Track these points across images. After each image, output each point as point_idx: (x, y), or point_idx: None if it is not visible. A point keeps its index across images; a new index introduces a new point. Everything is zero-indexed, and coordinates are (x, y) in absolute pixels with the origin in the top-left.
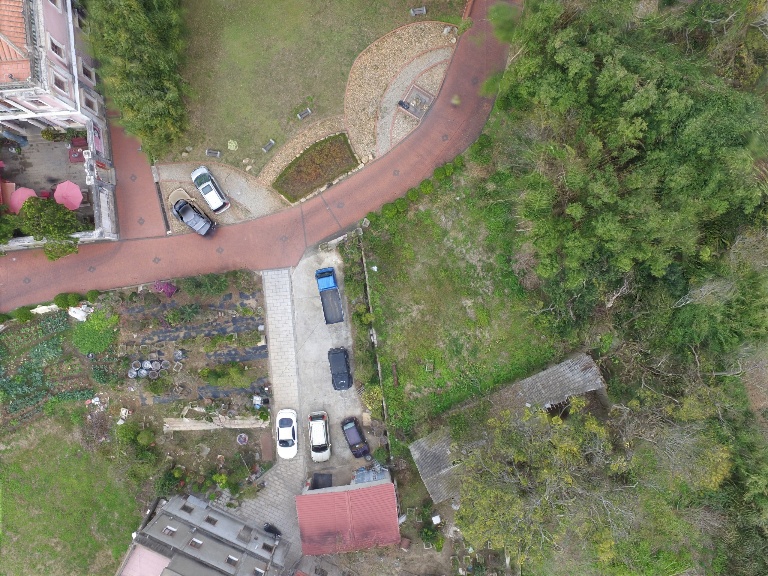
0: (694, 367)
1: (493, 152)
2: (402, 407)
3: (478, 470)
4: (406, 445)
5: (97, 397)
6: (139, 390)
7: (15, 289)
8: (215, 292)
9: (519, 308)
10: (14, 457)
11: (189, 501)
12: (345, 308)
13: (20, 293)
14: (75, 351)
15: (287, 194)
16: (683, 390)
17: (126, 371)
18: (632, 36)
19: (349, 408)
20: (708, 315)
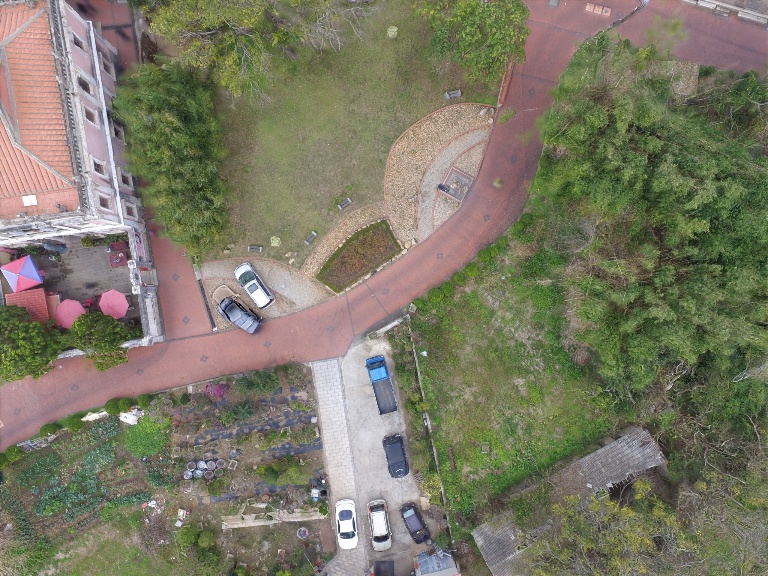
0: (754, 440)
1: (536, 230)
2: (460, 490)
3: (546, 559)
4: (468, 531)
5: (153, 500)
6: None
7: (63, 397)
8: (268, 391)
9: (575, 389)
10: (74, 565)
11: None
12: (396, 394)
13: (69, 401)
14: (128, 455)
15: (332, 285)
16: (745, 464)
17: (181, 473)
18: (674, 113)
19: (406, 493)
20: (763, 384)
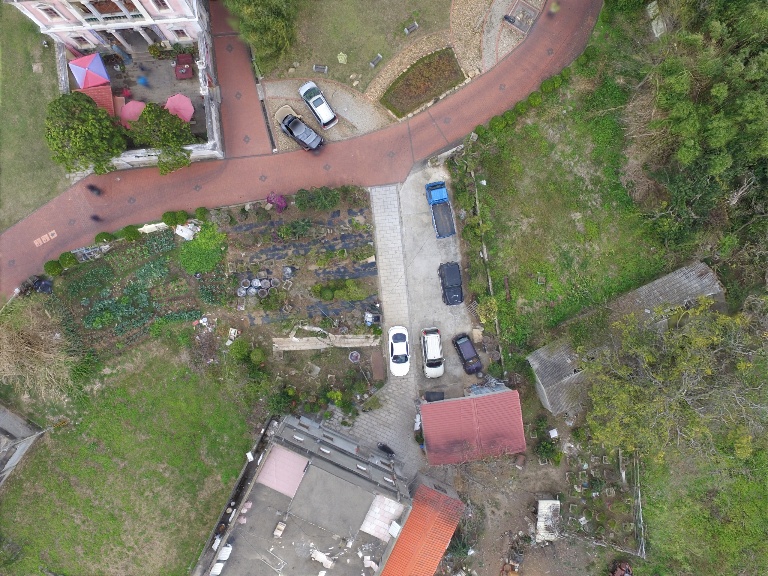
0: None
1: (599, 64)
2: (514, 321)
3: (606, 372)
4: (523, 356)
5: (205, 317)
6: (247, 310)
7: (120, 209)
8: (329, 204)
9: (635, 214)
10: (120, 381)
11: (302, 420)
12: None
13: (125, 213)
14: (181, 272)
15: (395, 109)
16: None
17: (235, 290)
18: None
19: (459, 325)
20: None
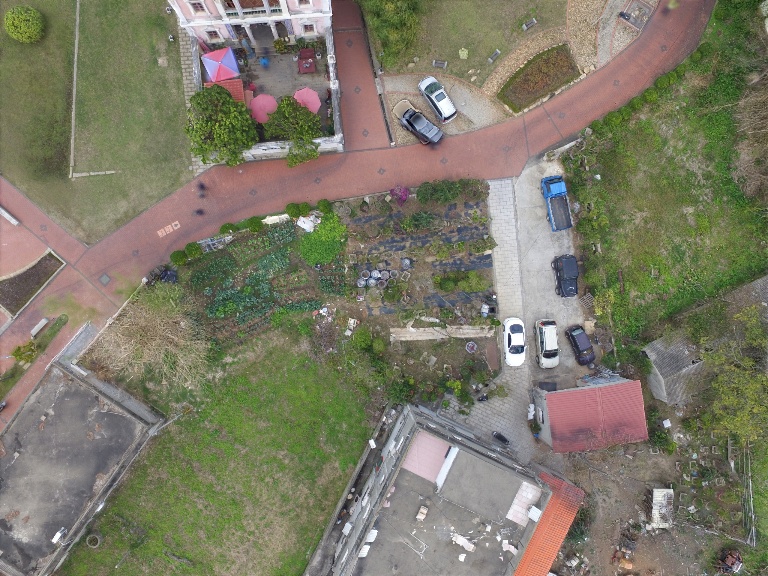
0: None
1: (713, 61)
2: (627, 313)
3: (730, 363)
4: (640, 347)
5: (325, 307)
6: (366, 300)
7: (241, 201)
8: (452, 197)
9: (753, 208)
10: (241, 369)
11: (421, 409)
12: None
13: (246, 205)
14: (301, 262)
15: (512, 104)
16: None
17: (354, 281)
18: None
19: (571, 317)
20: None
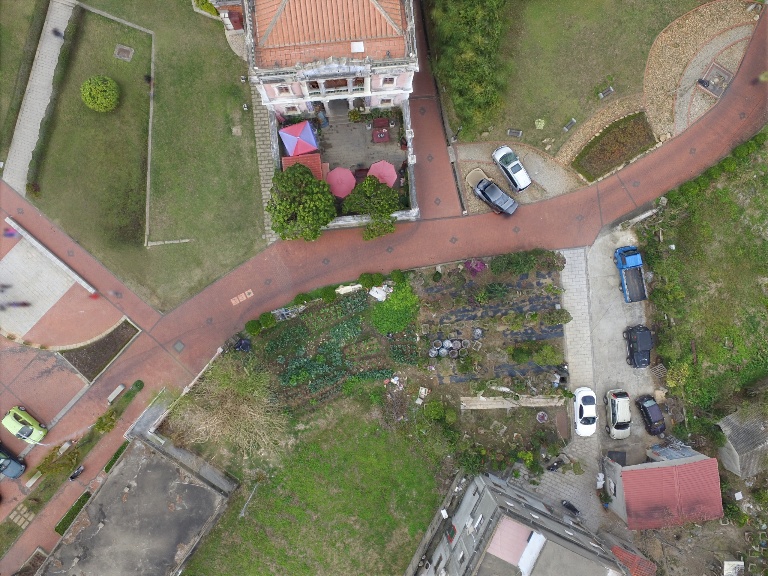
0: None
1: None
2: (699, 384)
3: None
4: (714, 421)
5: (397, 376)
6: (437, 369)
7: (314, 270)
8: (527, 270)
9: None
10: (313, 436)
11: (492, 479)
12: None
13: (319, 274)
14: (373, 331)
15: (587, 173)
16: None
17: (426, 350)
18: None
19: (642, 386)
20: None
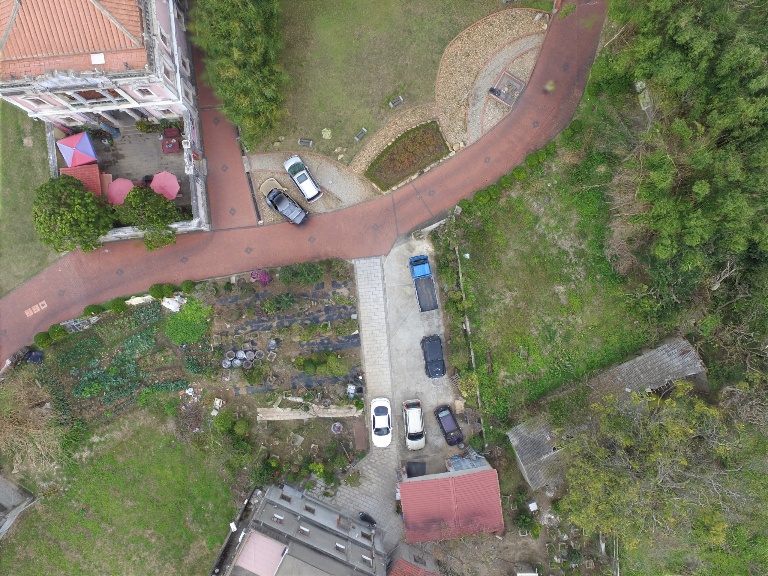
0: None
1: (585, 138)
2: (496, 394)
3: (584, 455)
4: (504, 432)
5: (191, 388)
6: (232, 380)
7: (108, 281)
8: (312, 280)
9: (618, 293)
10: (108, 449)
11: (285, 491)
12: (437, 296)
13: (113, 284)
14: (168, 342)
15: (379, 182)
16: None
17: (220, 361)
18: (731, 19)
19: (441, 396)
20: None
